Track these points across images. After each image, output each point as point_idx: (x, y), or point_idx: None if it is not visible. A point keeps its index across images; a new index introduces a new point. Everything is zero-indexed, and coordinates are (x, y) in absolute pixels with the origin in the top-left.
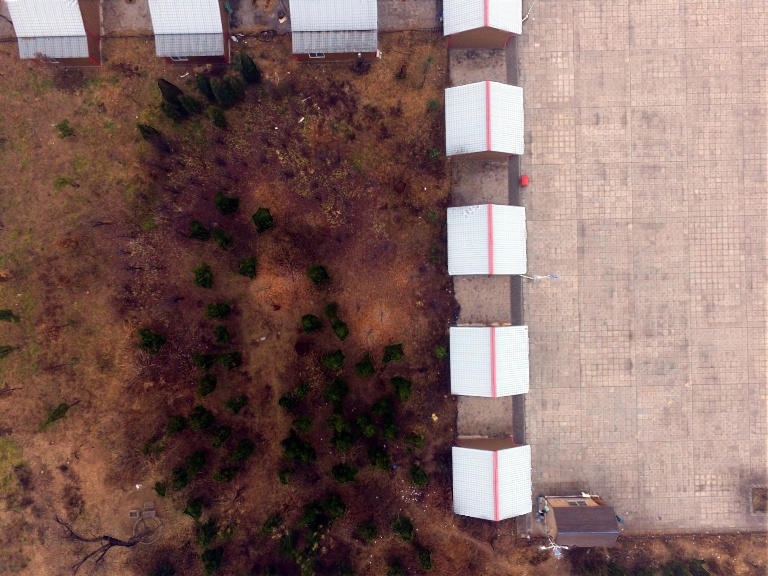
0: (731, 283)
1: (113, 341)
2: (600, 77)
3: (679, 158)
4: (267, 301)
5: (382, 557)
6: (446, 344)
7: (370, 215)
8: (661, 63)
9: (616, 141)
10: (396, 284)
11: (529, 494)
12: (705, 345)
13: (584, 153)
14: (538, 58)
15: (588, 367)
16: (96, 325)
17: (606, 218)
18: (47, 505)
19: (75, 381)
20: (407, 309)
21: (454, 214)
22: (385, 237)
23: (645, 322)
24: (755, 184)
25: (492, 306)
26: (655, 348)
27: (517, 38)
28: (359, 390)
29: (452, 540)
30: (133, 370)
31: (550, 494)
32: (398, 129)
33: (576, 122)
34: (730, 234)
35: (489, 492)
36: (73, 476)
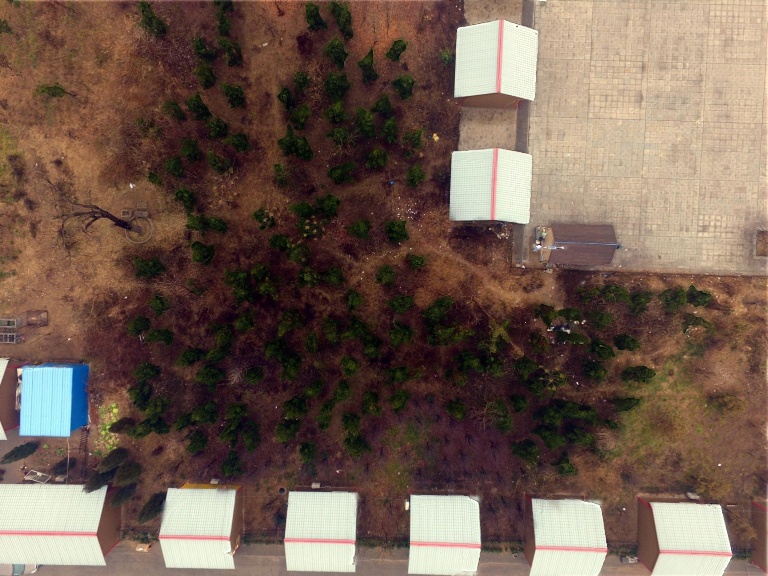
0: (752, 17)
1: (113, 36)
2: None
3: None
4: (271, 6)
5: (374, 274)
6: (452, 48)
7: None
8: None
9: None
10: None
11: (527, 204)
12: (720, 81)
13: None
14: None
15: (597, 98)
16: (96, 19)
17: None
18: (40, 199)
19: (73, 75)
20: (414, 23)
21: None
22: None
23: (659, 54)
24: None
25: None
26: (668, 81)
27: None
28: (360, 104)
29: (446, 261)
30: (131, 50)
31: (549, 226)
32: None
33: None
34: None
35: (487, 191)
36: (67, 171)
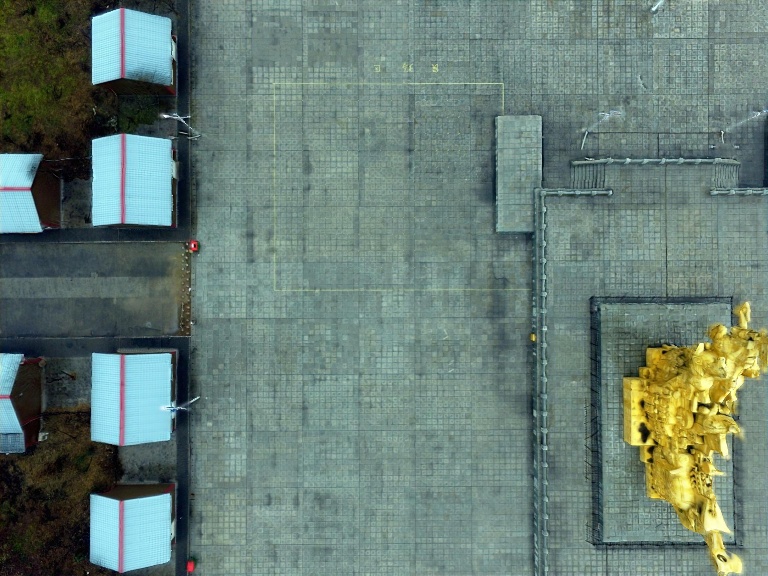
0: None
1: None
2: (272, 457)
3: (351, 541)
4: None
5: None
6: None
7: None
8: (334, 444)
9: (287, 522)
10: None
11: None
12: None
13: (255, 534)
14: (210, 437)
15: None
16: None
17: None
18: None
19: None
20: None
21: None
22: None
23: None
24: (427, 568)
25: None
26: None
27: (189, 417)
28: None
29: None
30: None
31: None
32: (61, 512)
33: (247, 503)
34: None
35: None
36: None
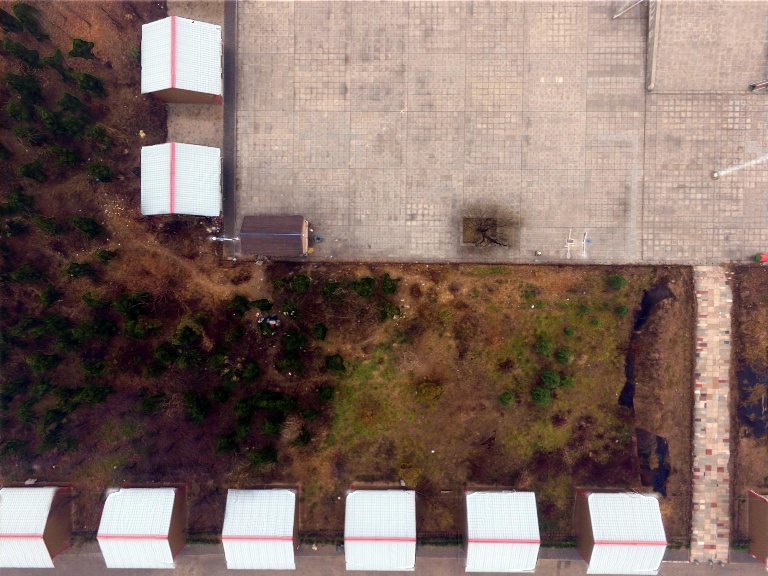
0: (451, 7)
1: None
2: None
3: None
4: None
5: None
6: None
7: None
8: None
9: None
10: None
11: (216, 197)
12: (422, 71)
13: None
14: None
15: (302, 90)
16: None
17: None
18: None
19: None
20: None
21: None
22: None
23: (362, 46)
24: None
25: None
26: (371, 73)
27: None
28: None
29: (154, 256)
30: None
31: None
32: None
33: None
34: None
35: (167, 185)
36: None
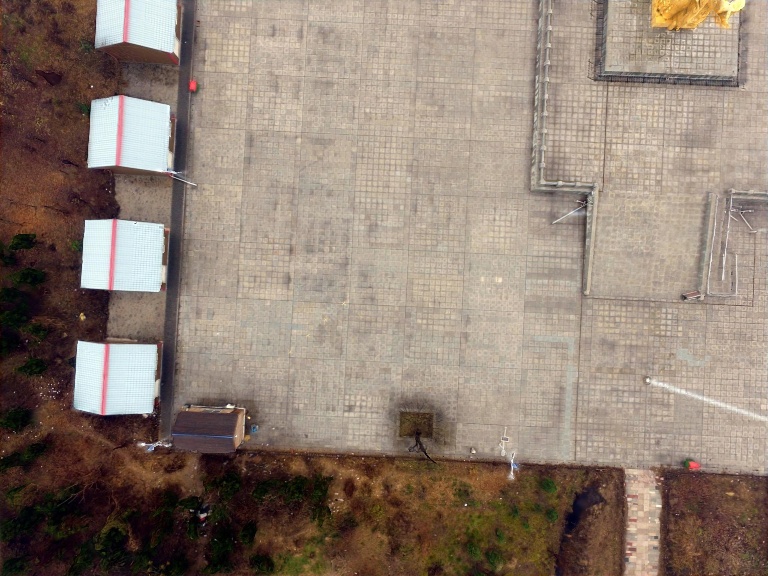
0: (396, 204)
1: None
2: None
3: (352, 76)
4: None
5: None
6: (82, 238)
7: (33, 108)
8: None
9: (290, 54)
10: (53, 179)
11: (151, 394)
12: (365, 265)
13: (258, 64)
14: None
15: (246, 278)
16: None
17: (275, 130)
18: None
19: None
20: (63, 205)
21: (96, 106)
22: (46, 131)
23: (307, 237)
24: (426, 107)
25: (152, 210)
26: (315, 264)
27: None
28: (7, 283)
29: (87, 441)
30: None
31: (197, 404)
32: (68, 25)
33: (252, 32)
34: (398, 155)
35: (99, 386)
36: None
